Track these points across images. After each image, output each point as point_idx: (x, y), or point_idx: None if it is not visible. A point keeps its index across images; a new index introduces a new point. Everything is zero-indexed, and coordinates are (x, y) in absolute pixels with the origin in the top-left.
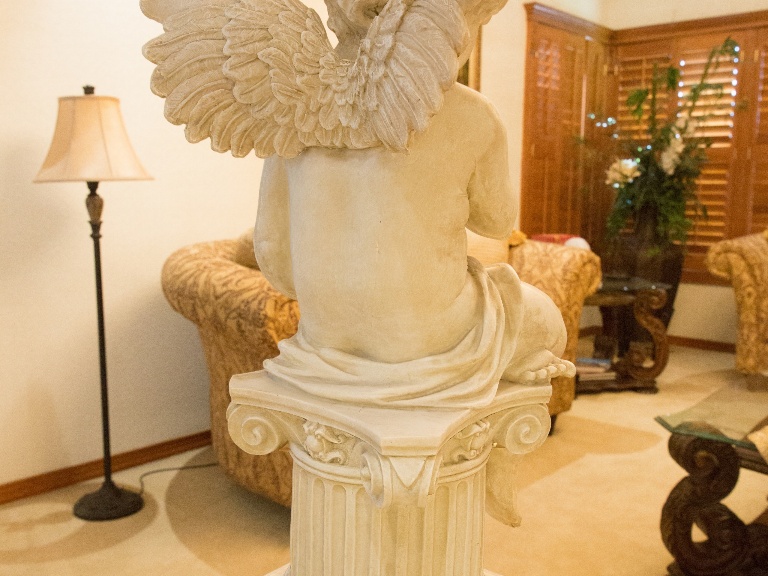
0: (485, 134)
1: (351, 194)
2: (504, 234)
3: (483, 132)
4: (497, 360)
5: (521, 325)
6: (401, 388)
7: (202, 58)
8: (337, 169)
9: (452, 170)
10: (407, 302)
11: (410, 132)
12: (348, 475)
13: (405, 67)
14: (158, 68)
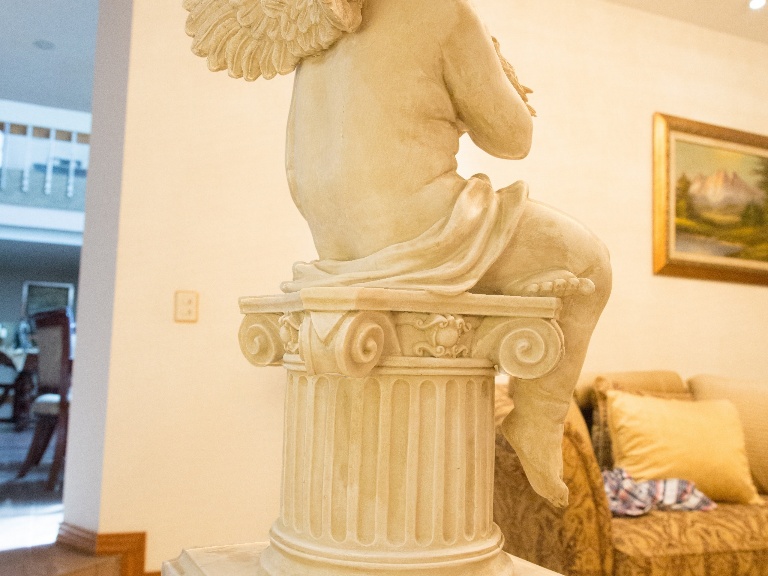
0: (446, 15)
1: (326, 90)
2: (514, 147)
3: (443, 13)
4: (473, 252)
5: (511, 223)
6: (362, 272)
7: None
8: (318, 72)
9: (410, 50)
10: (370, 185)
11: None
12: None
13: None
14: (190, 13)
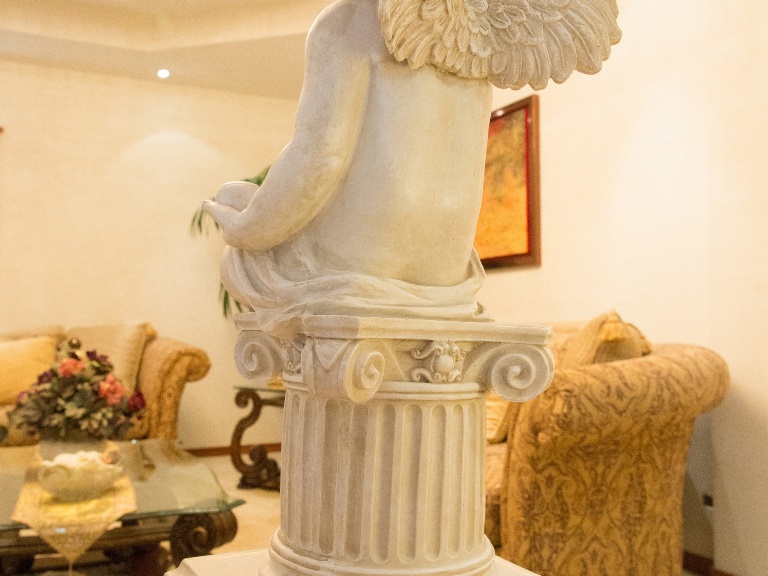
0: None
1: (455, 117)
2: None
3: None
4: None
5: None
6: None
7: None
8: (445, 91)
9: None
10: None
11: None
12: (470, 390)
13: (587, 19)
14: None
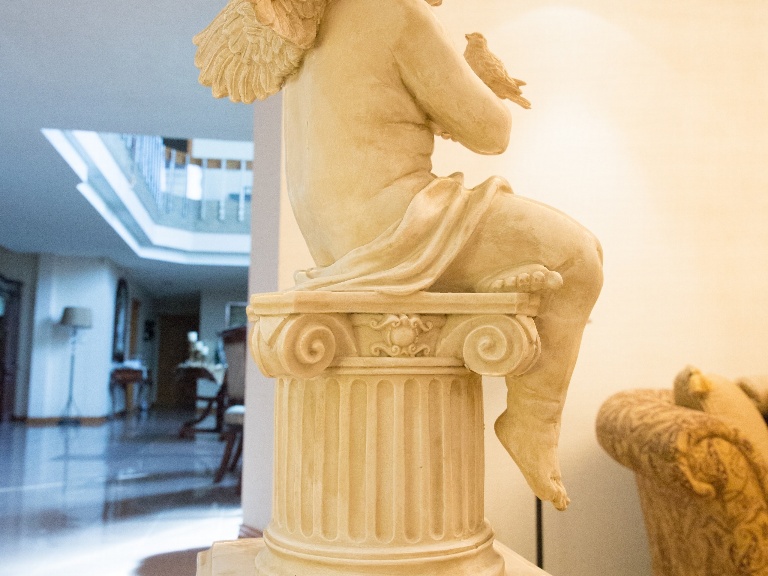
0: (393, 21)
1: None
2: (488, 142)
3: (391, 19)
4: (428, 251)
5: (470, 220)
6: (325, 277)
7: (216, 29)
8: (294, 89)
9: (361, 59)
10: (332, 192)
11: (254, 6)
12: None
13: None
14: None
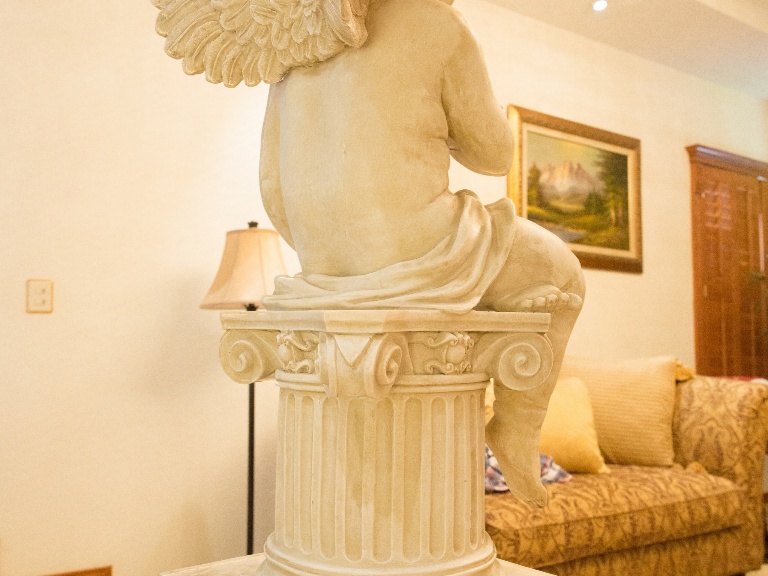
0: (449, 36)
1: (323, 104)
2: (500, 165)
3: (447, 34)
4: (477, 271)
5: (509, 242)
6: (369, 290)
7: None
8: (312, 84)
9: (415, 69)
10: (375, 203)
11: None
12: (314, 382)
13: None
14: (162, 11)
